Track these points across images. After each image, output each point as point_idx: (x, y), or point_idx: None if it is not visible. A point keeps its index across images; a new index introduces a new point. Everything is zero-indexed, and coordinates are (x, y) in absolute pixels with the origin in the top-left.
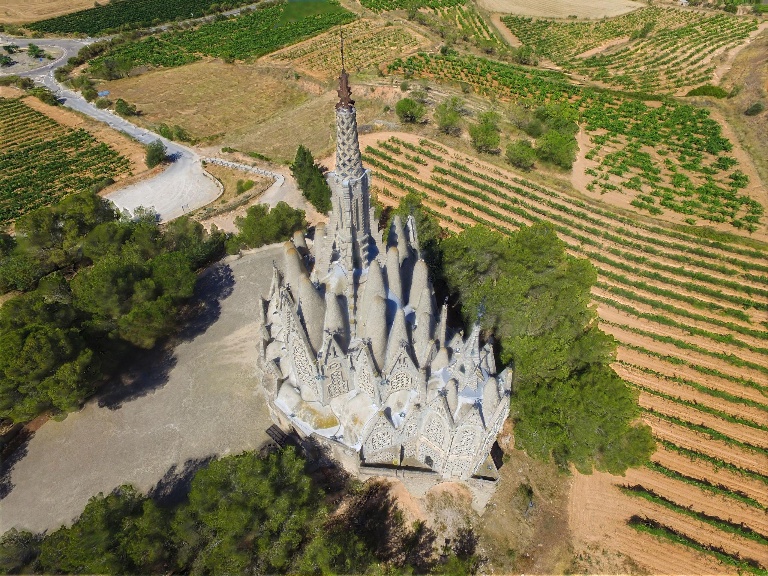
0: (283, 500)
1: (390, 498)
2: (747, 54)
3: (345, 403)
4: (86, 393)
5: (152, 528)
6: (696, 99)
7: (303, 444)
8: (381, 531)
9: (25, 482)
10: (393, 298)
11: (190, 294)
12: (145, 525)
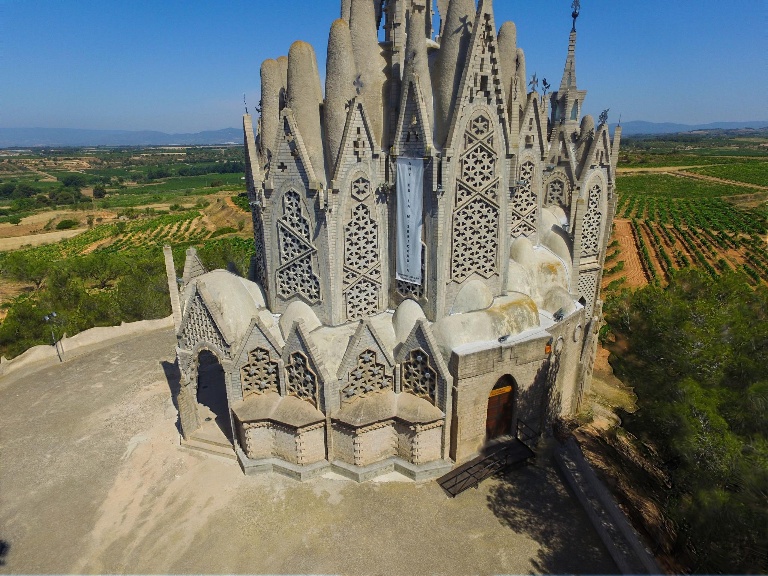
0: None
1: (585, 430)
2: (216, 216)
3: (520, 266)
4: None
5: None
6: (221, 237)
7: (520, 417)
8: (631, 464)
9: None
10: None
11: None
12: None
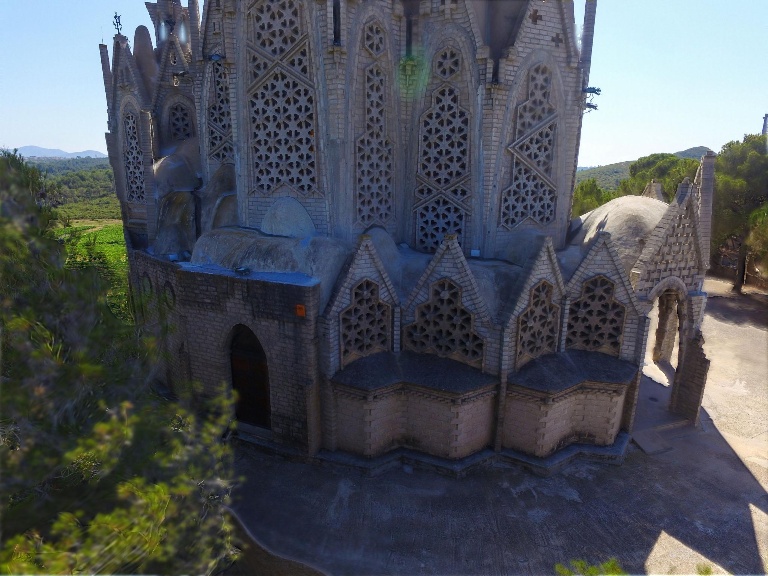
0: None
1: None
2: None
3: None
4: None
5: None
6: None
7: None
8: None
9: None
10: None
11: None
12: None
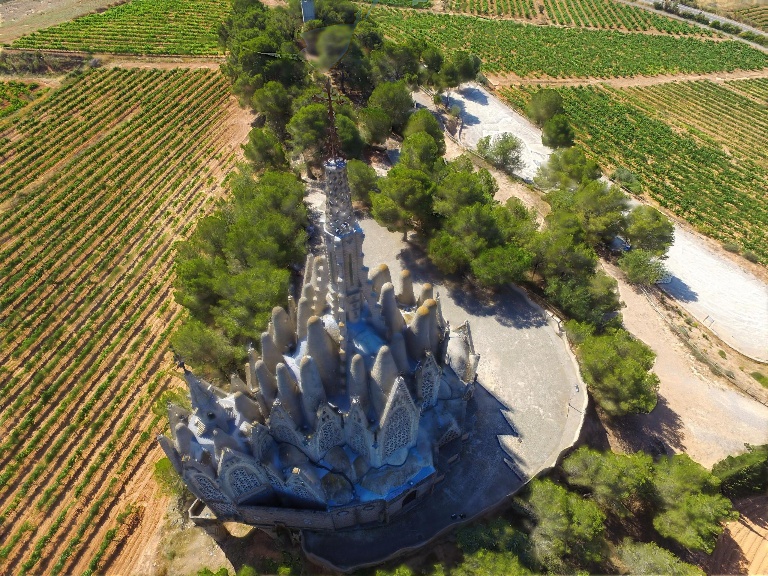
0: (242, 313)
1: None
2: None
3: None
4: (391, 228)
5: (259, 247)
6: None
7: None
8: None
9: (360, 225)
10: (302, 348)
11: (483, 281)
12: (260, 243)
